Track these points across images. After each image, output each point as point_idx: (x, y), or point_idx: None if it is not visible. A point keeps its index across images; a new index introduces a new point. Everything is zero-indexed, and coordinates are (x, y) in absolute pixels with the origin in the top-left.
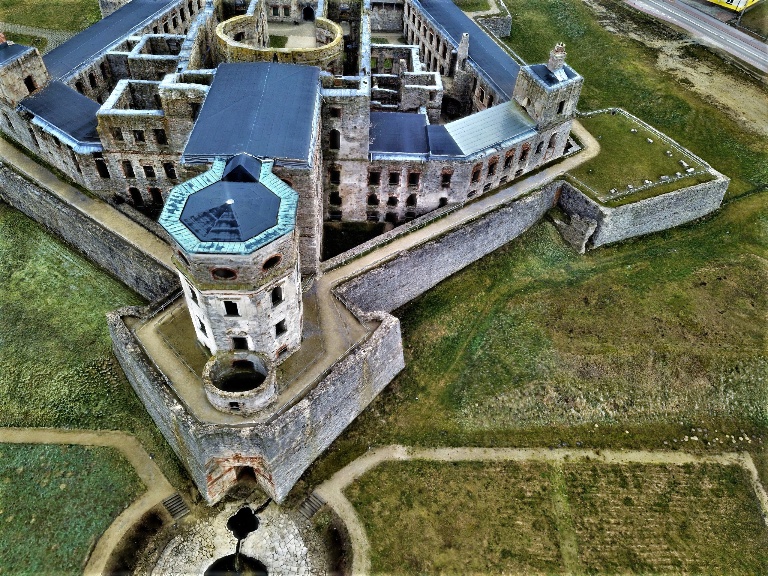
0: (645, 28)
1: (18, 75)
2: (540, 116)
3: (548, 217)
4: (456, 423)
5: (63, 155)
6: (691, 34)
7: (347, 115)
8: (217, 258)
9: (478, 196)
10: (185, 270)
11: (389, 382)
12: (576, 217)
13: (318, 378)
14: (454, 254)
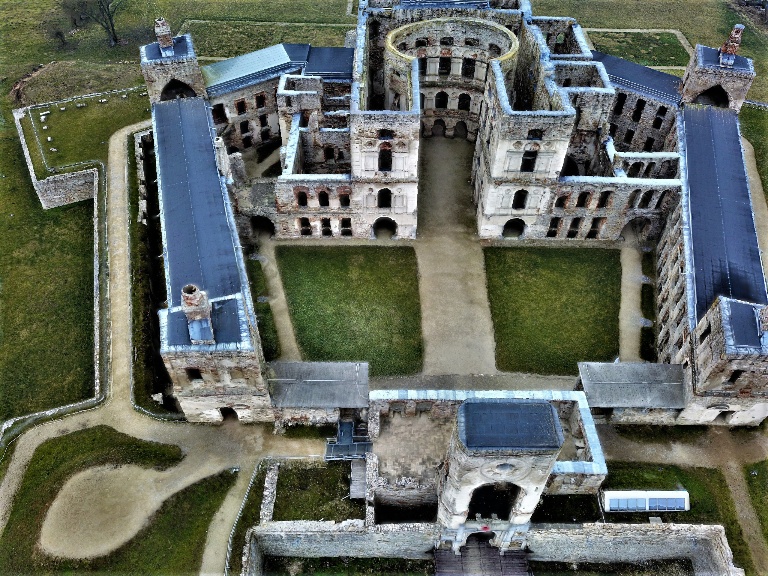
0: None
1: None
2: None
3: None
4: None
5: None
6: None
7: None
8: None
9: None
10: None
11: None
12: None
13: None
14: None
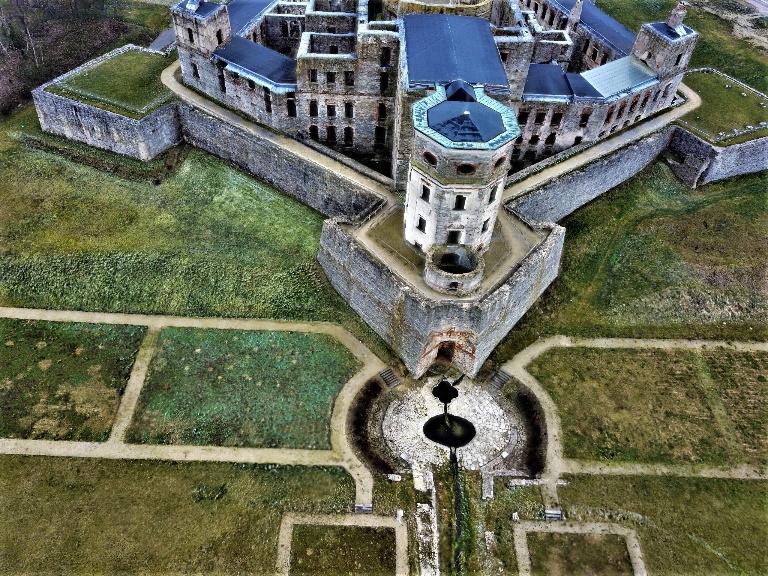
0: (716, 3)
1: (214, 28)
2: (662, 67)
3: (661, 158)
4: (607, 320)
5: (253, 97)
6: (758, 9)
7: (512, 59)
8: (466, 154)
9: (606, 137)
10: (427, 169)
11: (547, 287)
12: (691, 155)
13: (512, 270)
14: (591, 184)
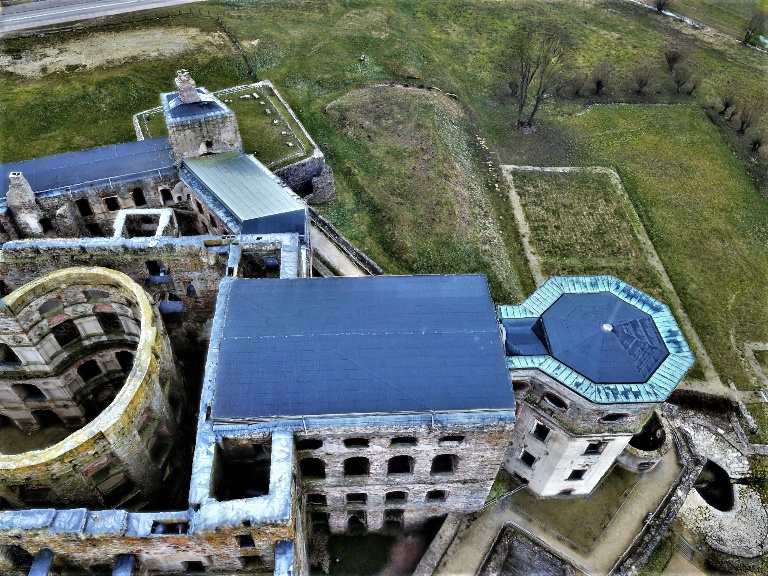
0: None
1: None
2: (238, 141)
3: None
4: None
5: None
6: None
7: None
8: None
9: None
10: None
11: None
12: (318, 179)
13: None
14: None
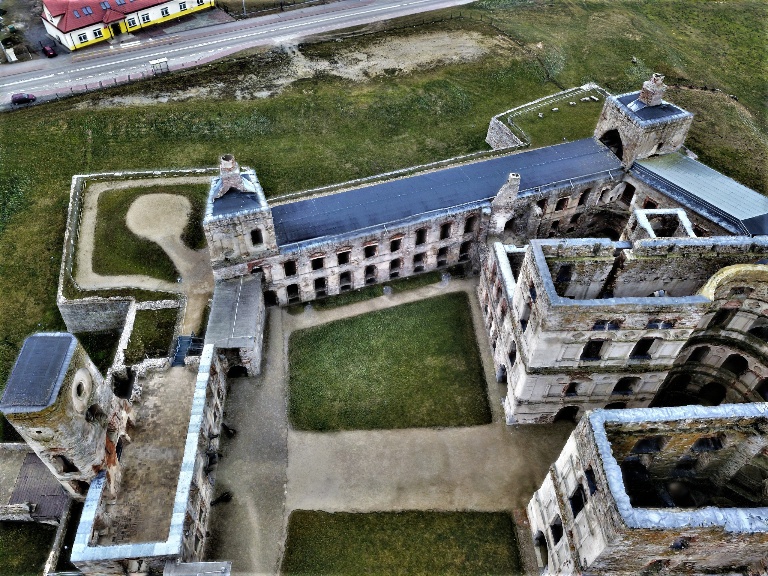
0: (259, 70)
1: None
2: (682, 142)
3: None
4: None
5: None
6: (269, 45)
7: None
8: None
9: None
10: None
11: None
12: None
13: None
14: None
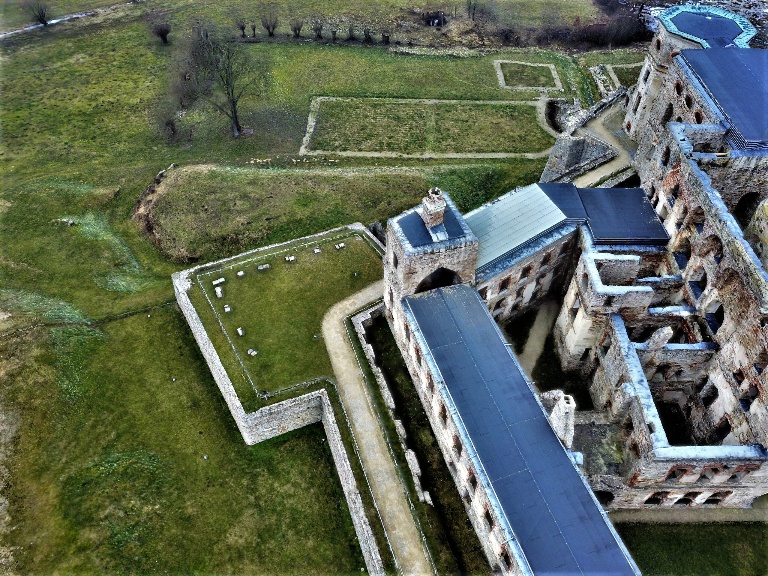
0: None
1: None
2: None
3: None
4: (495, 165)
5: None
6: None
7: None
8: None
9: None
10: None
11: None
12: None
13: None
14: None
